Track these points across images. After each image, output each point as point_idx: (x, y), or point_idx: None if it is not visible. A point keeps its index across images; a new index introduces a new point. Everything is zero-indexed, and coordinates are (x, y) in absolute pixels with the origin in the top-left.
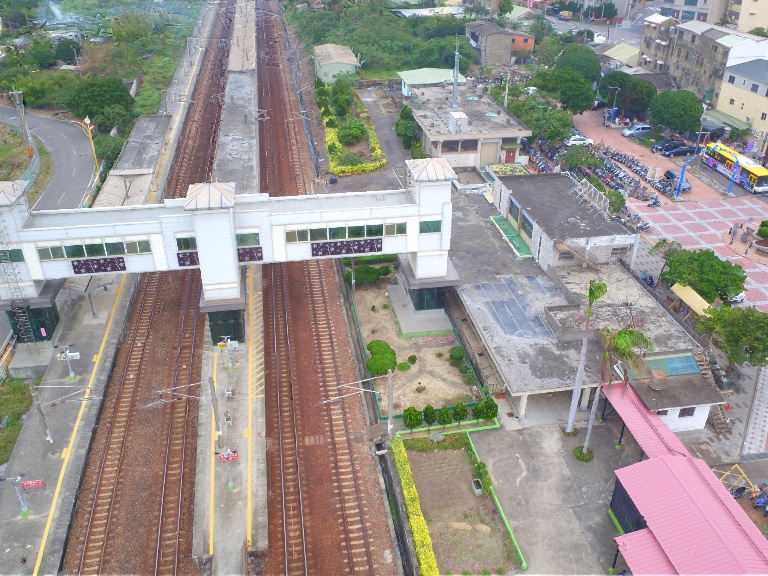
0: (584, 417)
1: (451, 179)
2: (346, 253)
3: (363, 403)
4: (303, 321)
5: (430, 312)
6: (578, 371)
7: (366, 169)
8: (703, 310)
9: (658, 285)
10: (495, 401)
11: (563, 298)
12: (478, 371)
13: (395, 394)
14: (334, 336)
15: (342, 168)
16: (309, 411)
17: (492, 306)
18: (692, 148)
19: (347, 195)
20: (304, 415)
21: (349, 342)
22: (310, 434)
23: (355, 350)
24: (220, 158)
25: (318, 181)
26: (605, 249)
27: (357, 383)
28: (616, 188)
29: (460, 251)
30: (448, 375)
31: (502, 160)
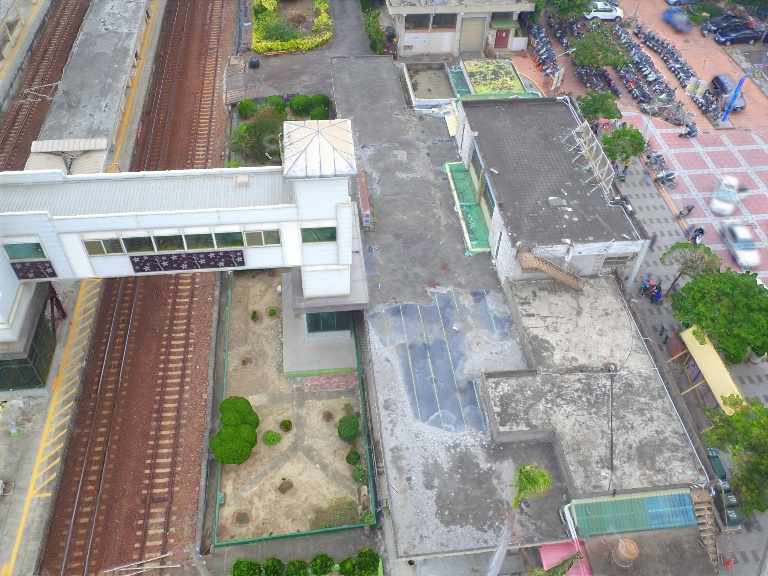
0: (511, 567)
1: (344, 175)
2: (188, 268)
3: (199, 505)
4: (151, 333)
5: (329, 334)
6: (498, 550)
7: (302, 47)
8: (721, 398)
9: (667, 295)
10: (388, 521)
11: (517, 343)
12: (375, 457)
13: (247, 493)
14: (189, 364)
15: (268, 44)
16: (117, 518)
17: (408, 355)
18: (759, 33)
19: (191, 174)
20: (108, 526)
21: (207, 378)
22: (108, 567)
23: (215, 390)
24: (88, 30)
25: (235, 62)
26: (594, 259)
27: (200, 463)
28: (640, 100)
29: (387, 233)
30: (332, 458)
31: (490, 43)
